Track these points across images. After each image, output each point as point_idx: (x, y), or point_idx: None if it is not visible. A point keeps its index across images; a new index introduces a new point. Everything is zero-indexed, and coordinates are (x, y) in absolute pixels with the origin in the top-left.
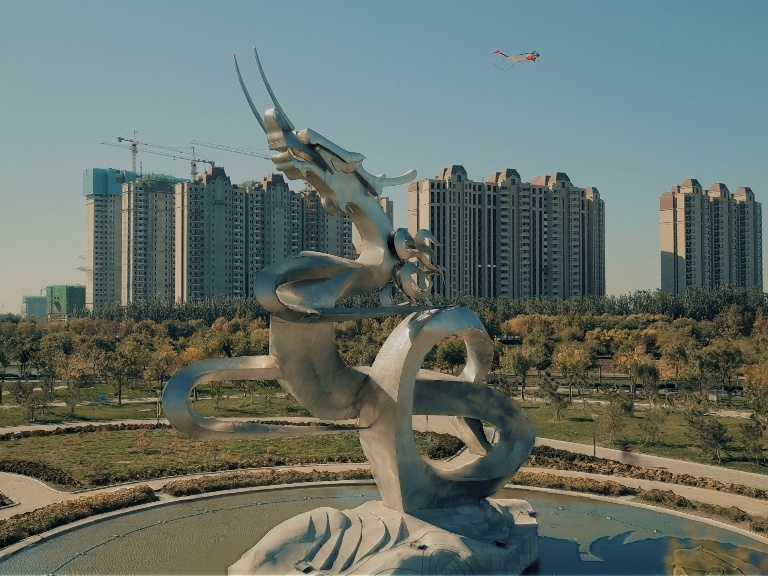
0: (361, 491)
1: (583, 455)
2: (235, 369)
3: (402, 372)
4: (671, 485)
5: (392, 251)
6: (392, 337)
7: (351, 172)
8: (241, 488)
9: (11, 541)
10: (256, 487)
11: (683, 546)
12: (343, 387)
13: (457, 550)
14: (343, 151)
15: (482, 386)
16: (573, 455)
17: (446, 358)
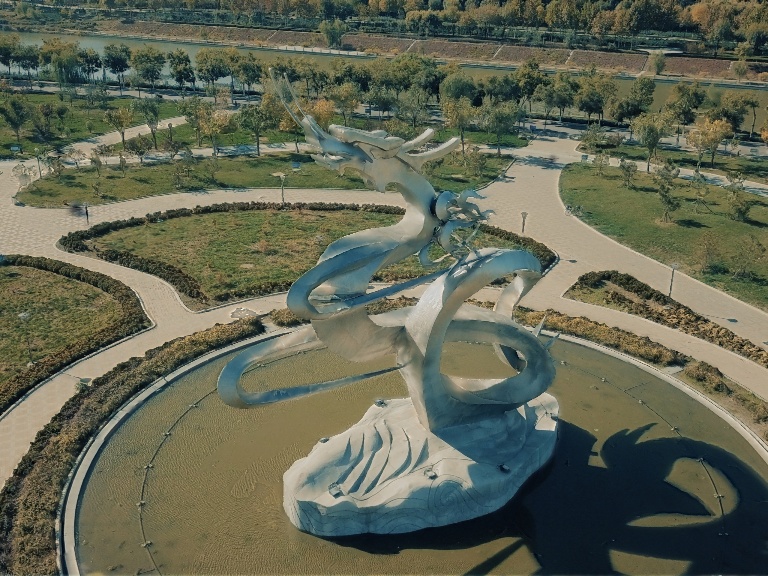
0: None
1: (660, 295)
2: (279, 350)
3: (431, 332)
4: (726, 352)
5: (434, 215)
6: (429, 292)
7: (391, 157)
8: None
9: (144, 385)
10: None
11: (689, 453)
12: (381, 339)
13: (461, 481)
14: (382, 141)
15: (513, 327)
16: (650, 294)
17: (582, 107)
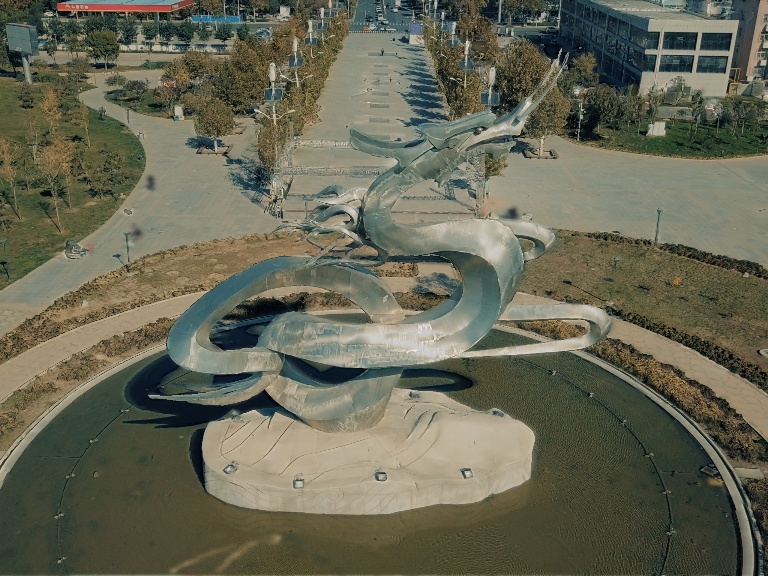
0: None
1: None
2: None
3: None
4: None
5: None
6: None
7: None
8: None
9: None
10: None
11: None
12: None
13: None
14: None
15: None
16: None
17: None
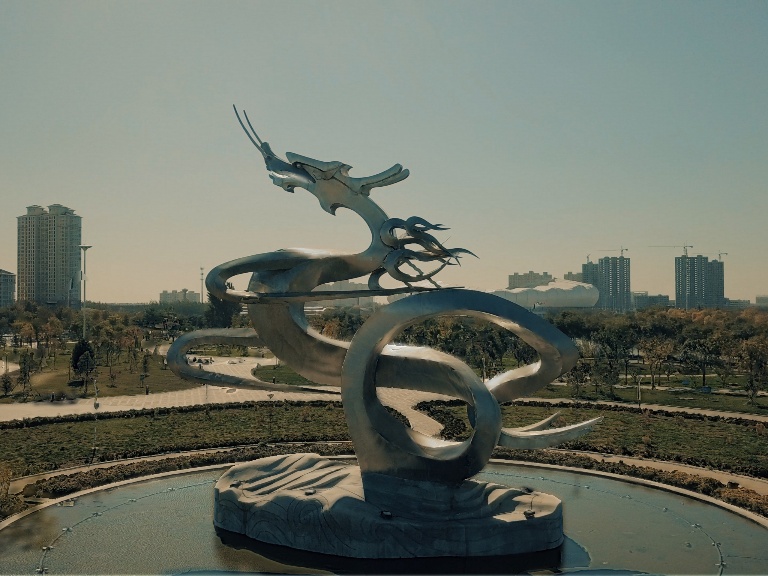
0: (607, 485)
1: None
2: (222, 337)
3: (350, 347)
4: None
5: None
6: None
7: (331, 178)
8: (518, 461)
9: None
10: (531, 462)
11: None
12: (326, 357)
13: (325, 503)
14: (320, 163)
15: None
16: None
17: None
